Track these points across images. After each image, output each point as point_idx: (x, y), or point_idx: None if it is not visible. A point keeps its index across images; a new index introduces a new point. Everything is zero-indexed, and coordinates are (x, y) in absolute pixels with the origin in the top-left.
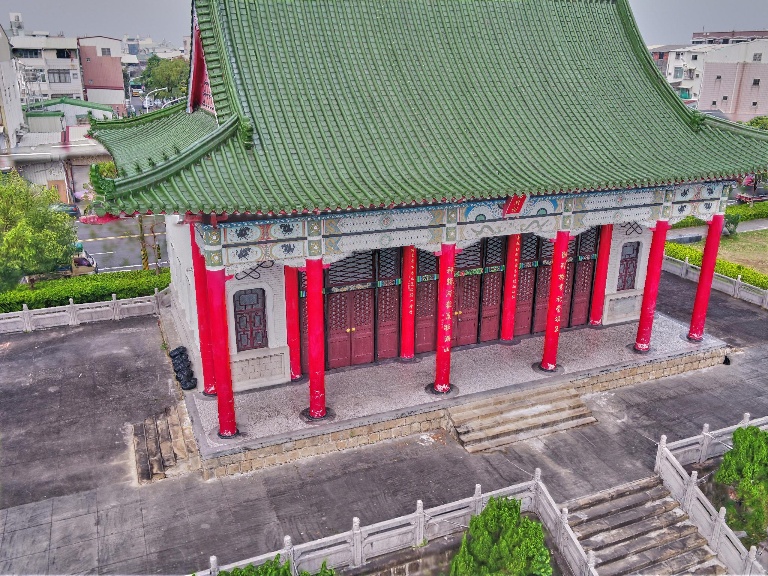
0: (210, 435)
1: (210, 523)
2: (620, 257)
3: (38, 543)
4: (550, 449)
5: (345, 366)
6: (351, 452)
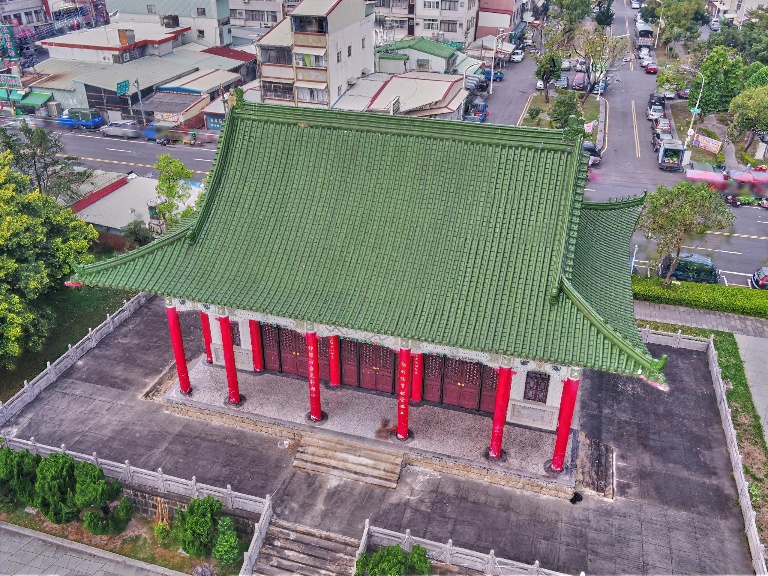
0: (178, 388)
1: (141, 434)
2: (526, 374)
3: (82, 407)
4: (336, 489)
5: (293, 374)
6: (240, 431)
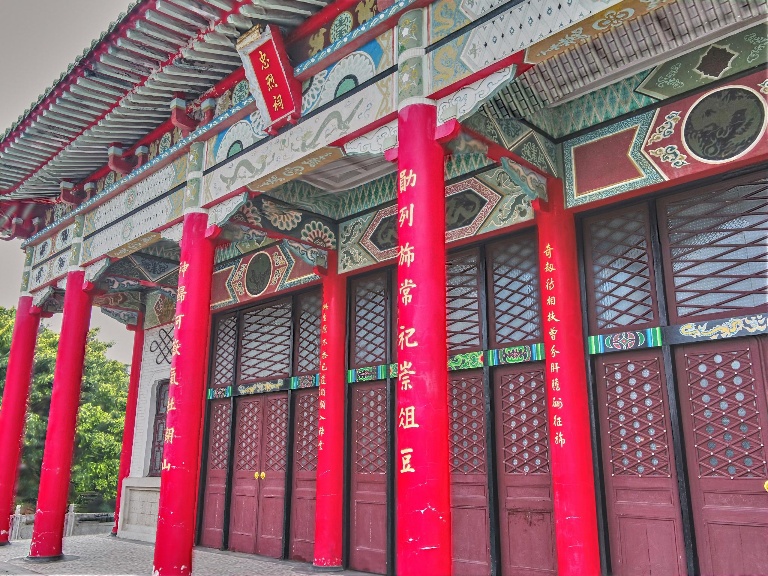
0: None
1: None
2: None
3: None
4: None
5: (247, 552)
6: None
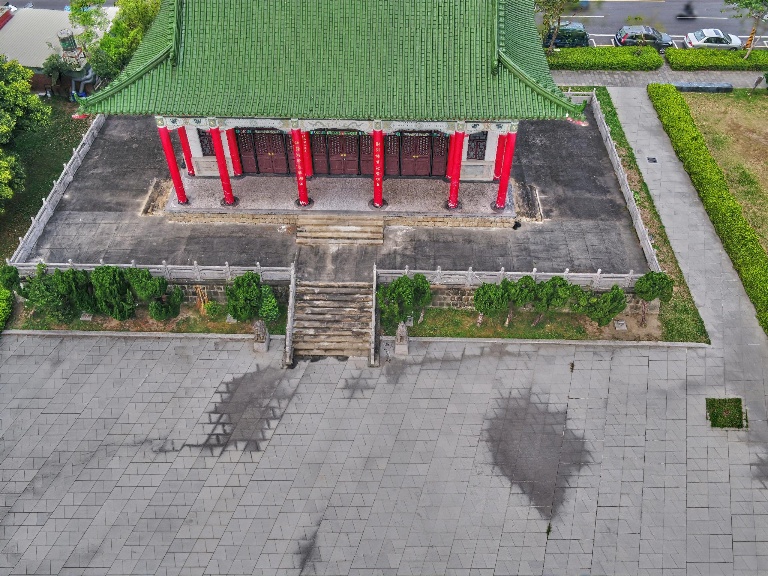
0: (175, 200)
1: (157, 243)
2: (468, 138)
3: (92, 232)
4: (337, 253)
5: (270, 173)
6: (241, 225)
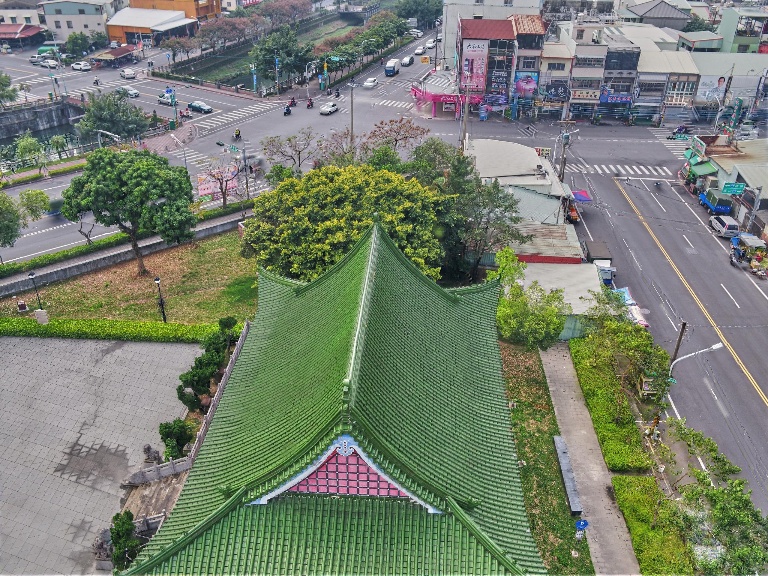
0: None
1: None
2: None
3: None
4: None
5: None
6: None
